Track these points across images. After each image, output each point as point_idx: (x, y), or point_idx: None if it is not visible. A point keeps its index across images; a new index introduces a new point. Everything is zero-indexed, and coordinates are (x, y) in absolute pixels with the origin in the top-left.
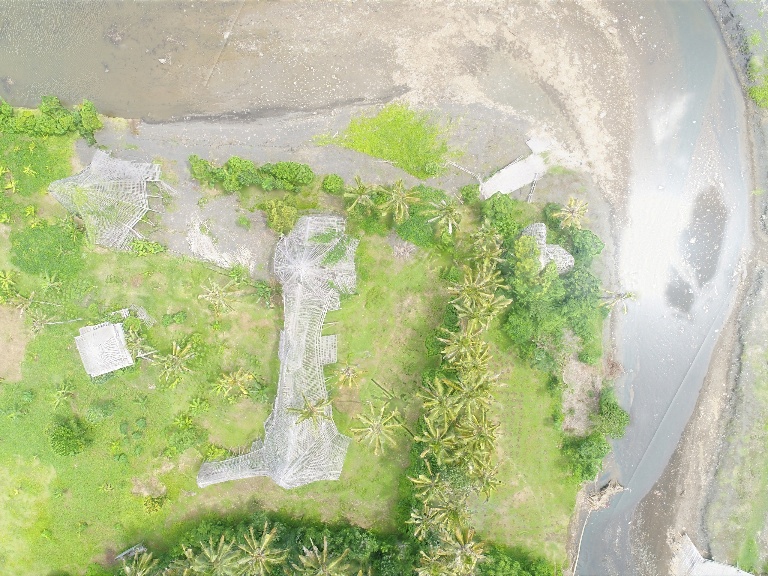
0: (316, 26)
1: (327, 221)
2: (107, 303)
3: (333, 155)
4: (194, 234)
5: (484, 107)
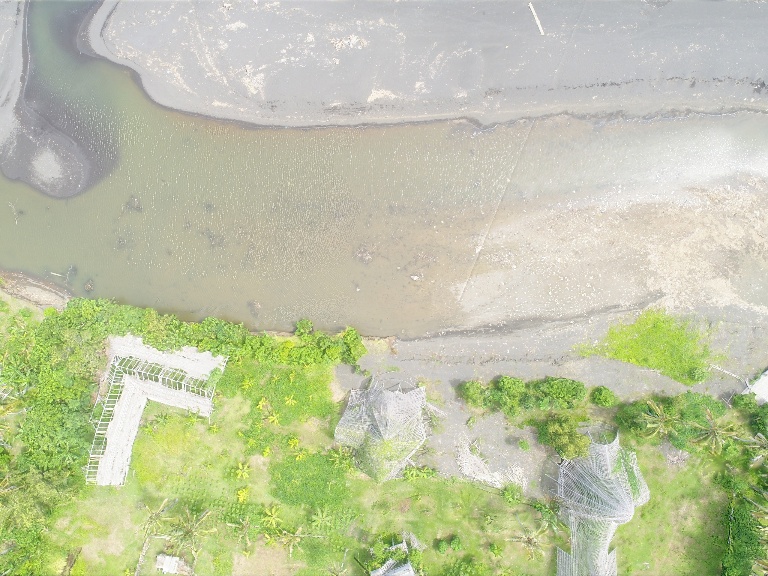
0: (567, 237)
1: (616, 444)
2: (374, 531)
3: (599, 366)
4: (465, 456)
5: (739, 308)
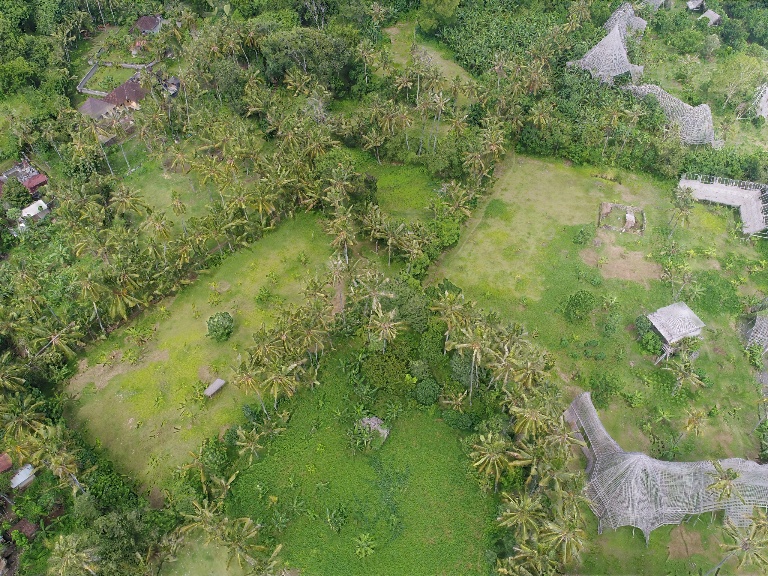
0: None
1: None
2: None
3: None
4: None
5: None
